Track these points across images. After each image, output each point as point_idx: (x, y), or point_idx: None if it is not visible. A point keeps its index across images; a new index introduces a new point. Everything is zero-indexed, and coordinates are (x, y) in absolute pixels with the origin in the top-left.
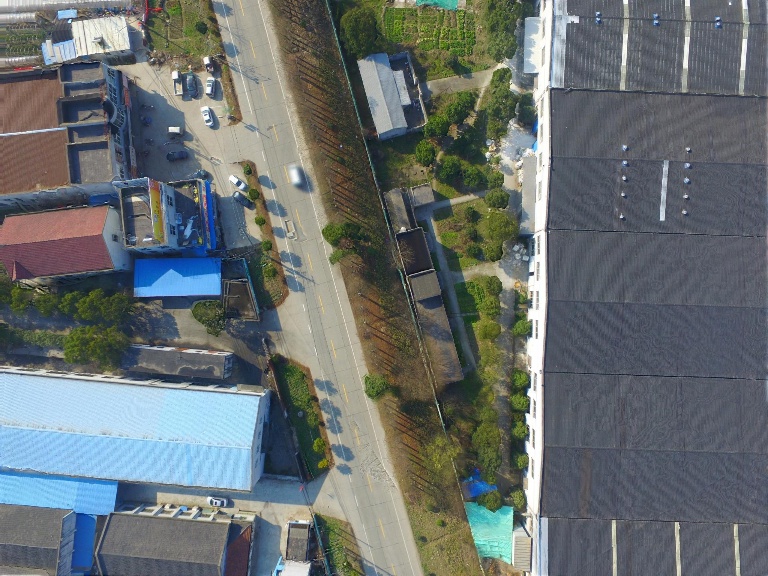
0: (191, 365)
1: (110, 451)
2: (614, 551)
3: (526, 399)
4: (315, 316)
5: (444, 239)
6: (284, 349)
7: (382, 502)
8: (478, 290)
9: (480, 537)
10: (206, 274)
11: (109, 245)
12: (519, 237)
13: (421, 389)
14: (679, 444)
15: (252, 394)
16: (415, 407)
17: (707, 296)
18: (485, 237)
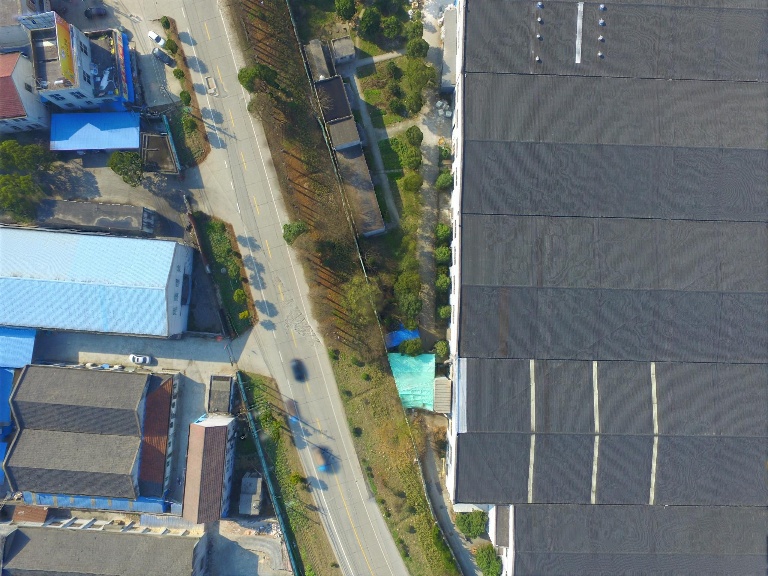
0: (108, 216)
1: (22, 295)
2: (532, 389)
3: (448, 249)
4: (237, 172)
5: (367, 96)
6: (206, 206)
7: (307, 357)
8: (402, 147)
9: (403, 387)
10: (124, 128)
11: (21, 91)
12: (442, 93)
13: (345, 244)
14: (595, 282)
15: (168, 240)
16: (339, 261)
17: (622, 136)
18: (408, 94)
